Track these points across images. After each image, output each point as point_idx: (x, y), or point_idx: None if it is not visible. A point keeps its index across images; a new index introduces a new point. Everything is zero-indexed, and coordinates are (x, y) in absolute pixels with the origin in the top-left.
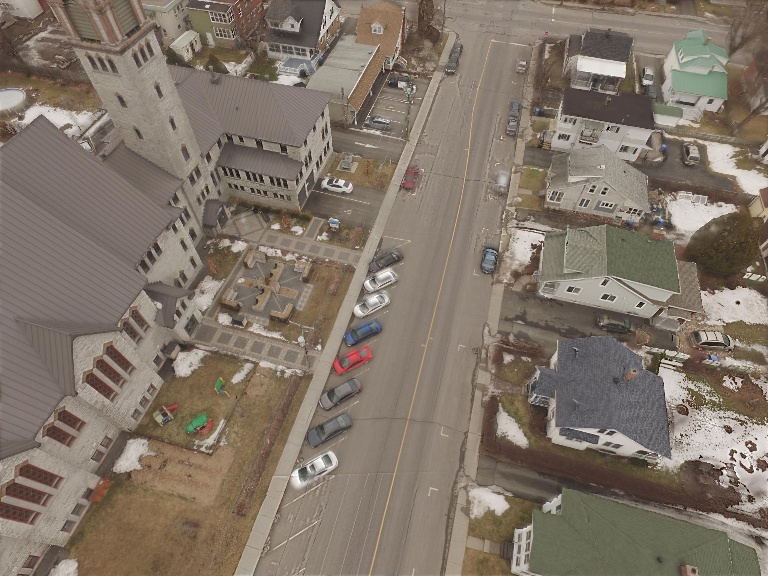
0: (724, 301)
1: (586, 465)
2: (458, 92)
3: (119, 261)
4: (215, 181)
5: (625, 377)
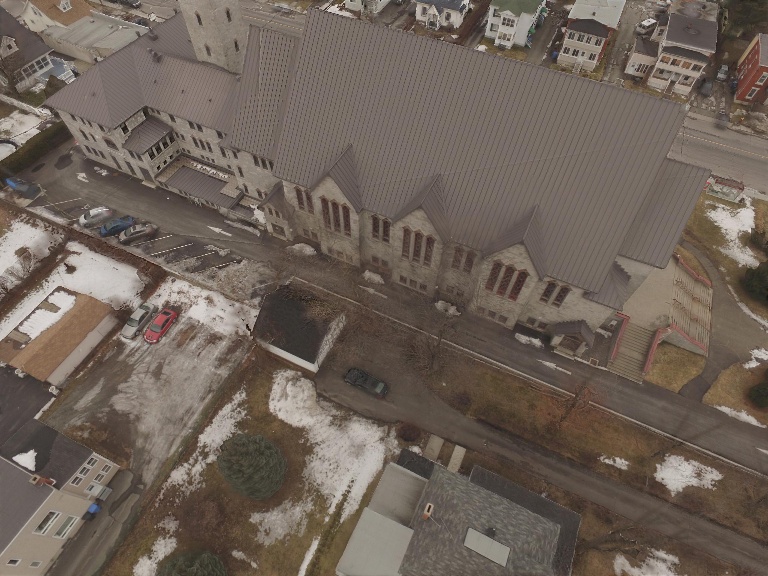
0: None
1: (472, 17)
2: (167, 8)
3: None
4: None
5: None
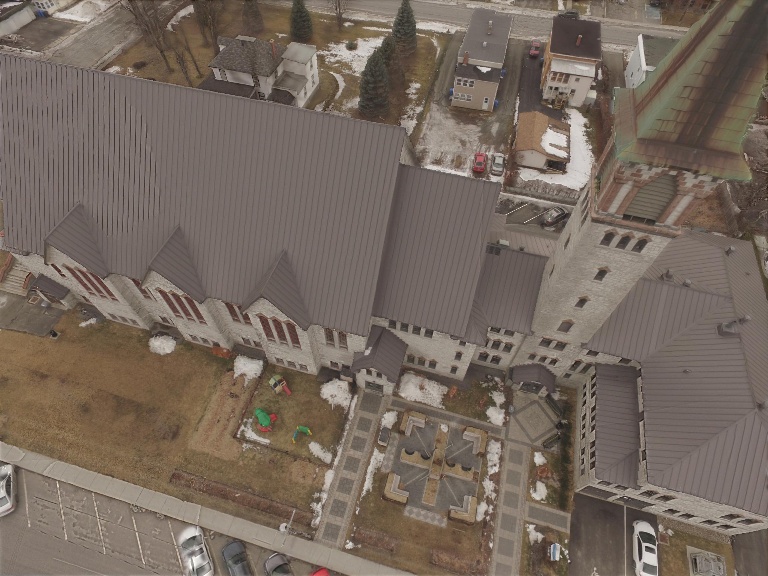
0: None
1: None
2: None
3: (371, 306)
4: (576, 367)
5: None
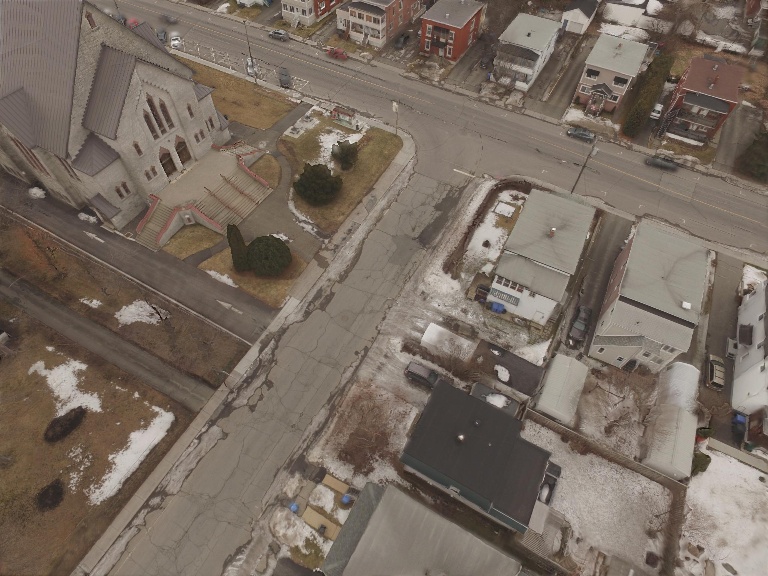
0: None
1: None
2: None
3: None
4: None
5: None
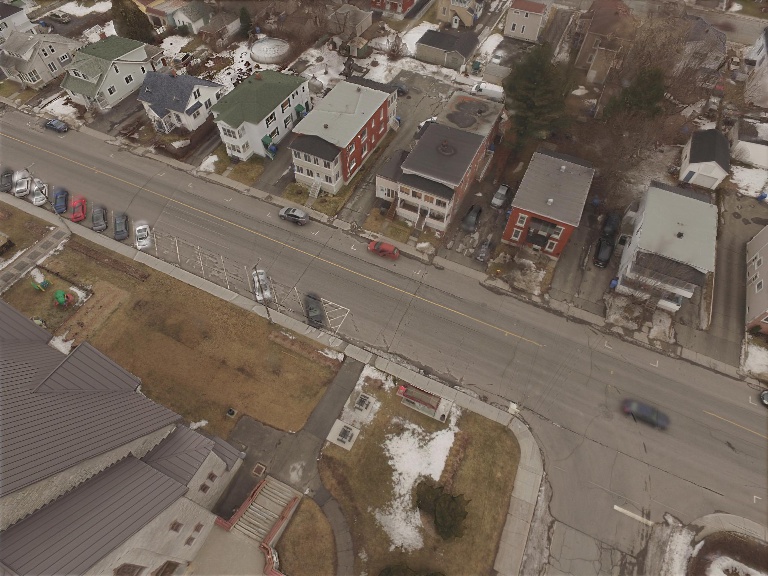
0: (167, 48)
1: (212, 117)
2: None
3: None
4: None
5: (174, 76)
